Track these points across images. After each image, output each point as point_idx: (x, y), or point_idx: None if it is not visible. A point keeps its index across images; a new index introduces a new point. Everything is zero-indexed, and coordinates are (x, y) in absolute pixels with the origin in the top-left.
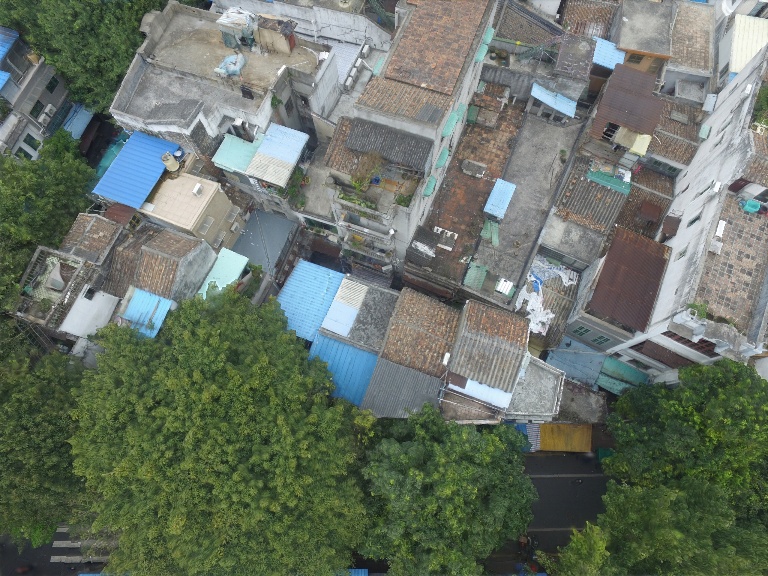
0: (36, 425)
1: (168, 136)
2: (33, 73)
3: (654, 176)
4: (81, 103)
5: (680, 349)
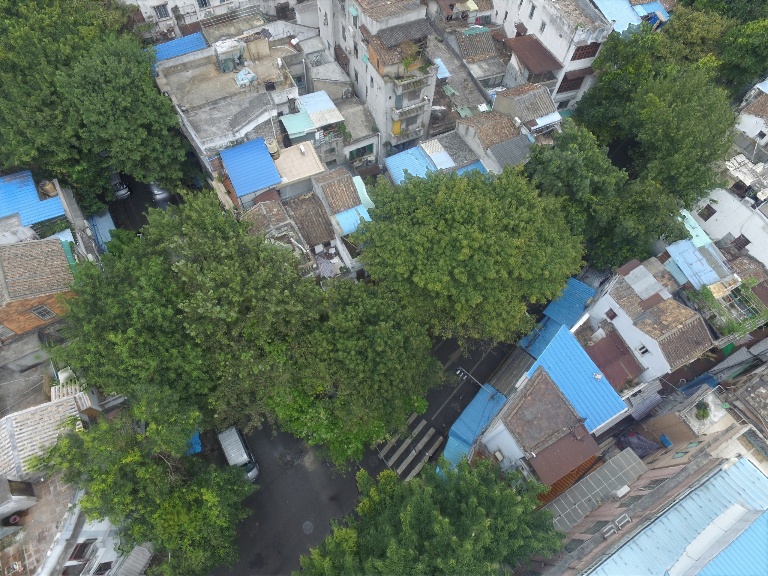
0: None
1: (253, 133)
2: (63, 196)
3: None
4: (92, 218)
5: (580, 65)
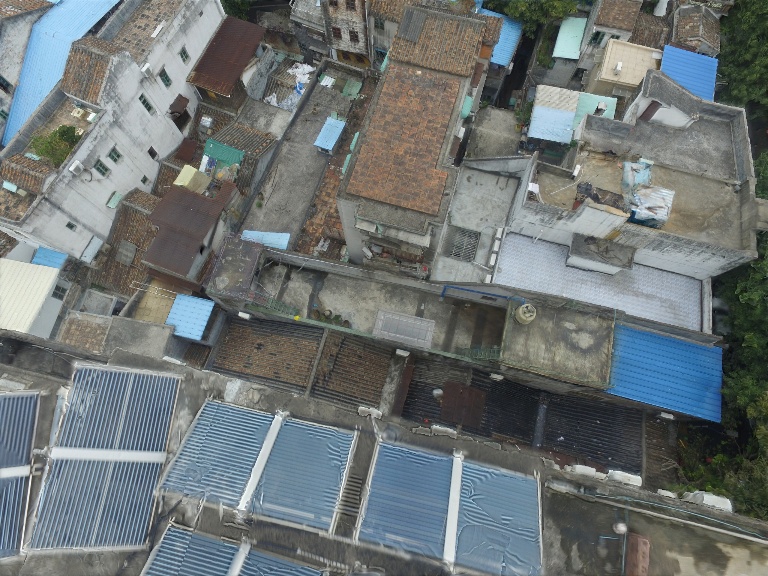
0: None
1: None
2: None
3: None
4: None
5: None
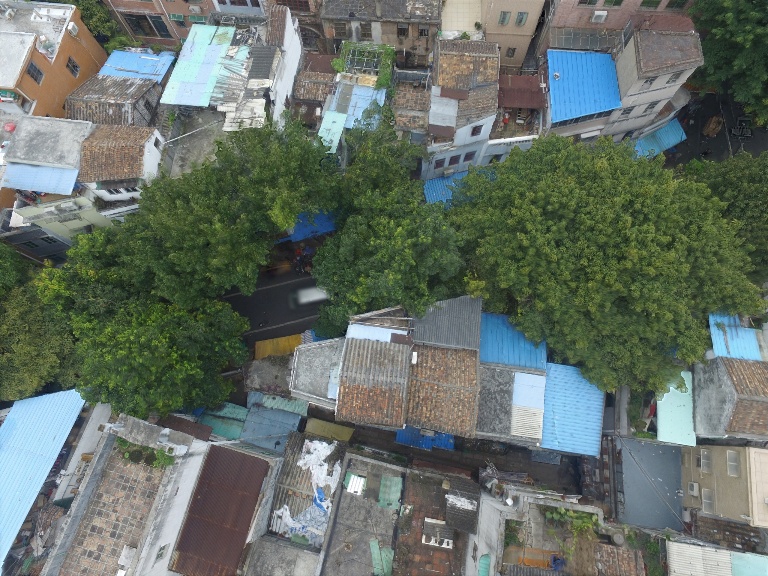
0: (764, 212)
1: None
2: None
3: None
4: None
5: None
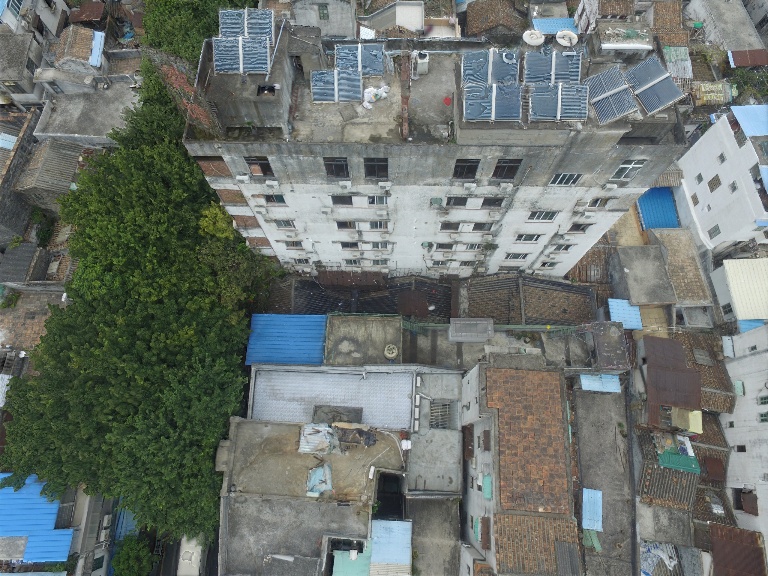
0: None
1: None
2: (88, 504)
3: None
4: None
5: None
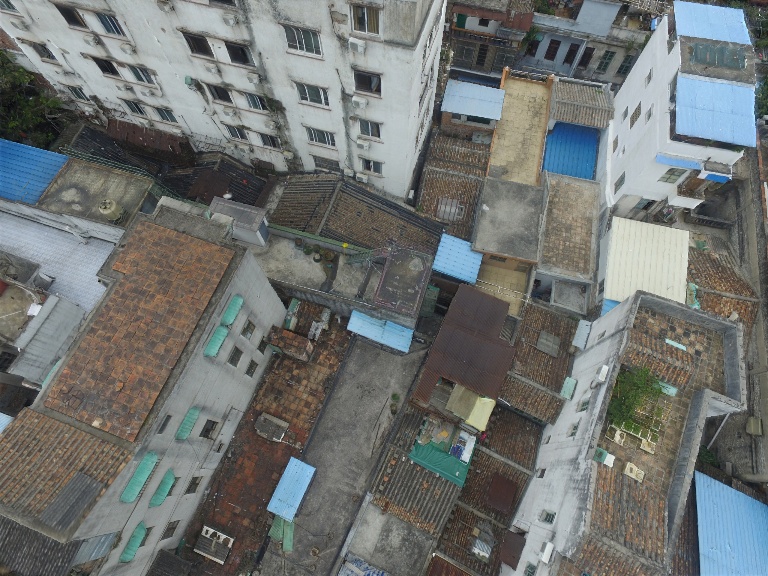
0: None
1: None
2: None
3: (516, 426)
4: None
5: None
